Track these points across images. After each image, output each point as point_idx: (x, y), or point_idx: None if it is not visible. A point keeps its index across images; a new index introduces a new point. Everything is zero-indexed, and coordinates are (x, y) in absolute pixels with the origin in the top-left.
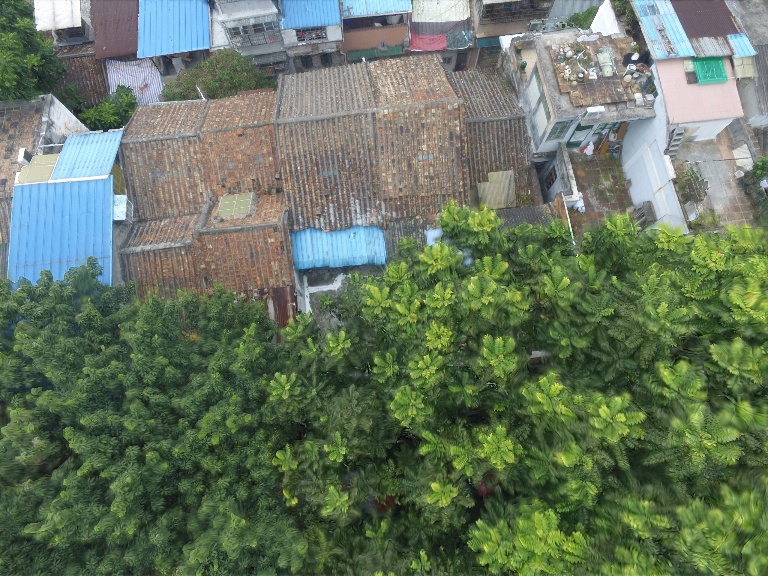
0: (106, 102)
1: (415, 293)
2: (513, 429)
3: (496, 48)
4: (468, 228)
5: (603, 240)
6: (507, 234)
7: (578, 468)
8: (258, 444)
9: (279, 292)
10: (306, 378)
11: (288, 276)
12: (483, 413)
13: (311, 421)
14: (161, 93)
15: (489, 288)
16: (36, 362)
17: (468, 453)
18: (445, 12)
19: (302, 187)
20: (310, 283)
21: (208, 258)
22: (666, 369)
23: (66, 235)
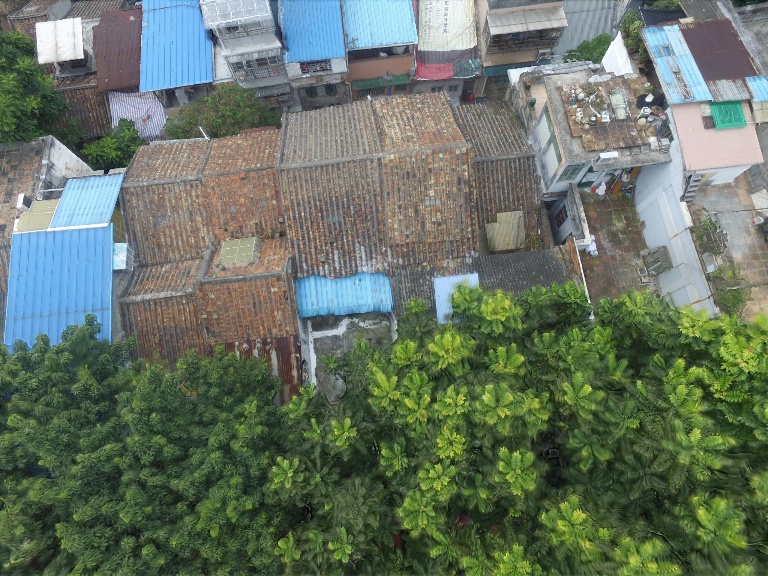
0: (108, 136)
1: (425, 384)
2: (531, 543)
3: (503, 76)
4: (481, 315)
5: (622, 318)
6: (520, 301)
7: None
8: (260, 528)
9: (282, 342)
10: (310, 460)
11: (292, 326)
12: (497, 516)
13: (315, 505)
14: (163, 128)
15: (505, 399)
16: (29, 446)
17: (482, 565)
18: (451, 40)
19: (306, 234)
20: (314, 328)
21: (210, 308)
22: (701, 507)
23: (65, 286)
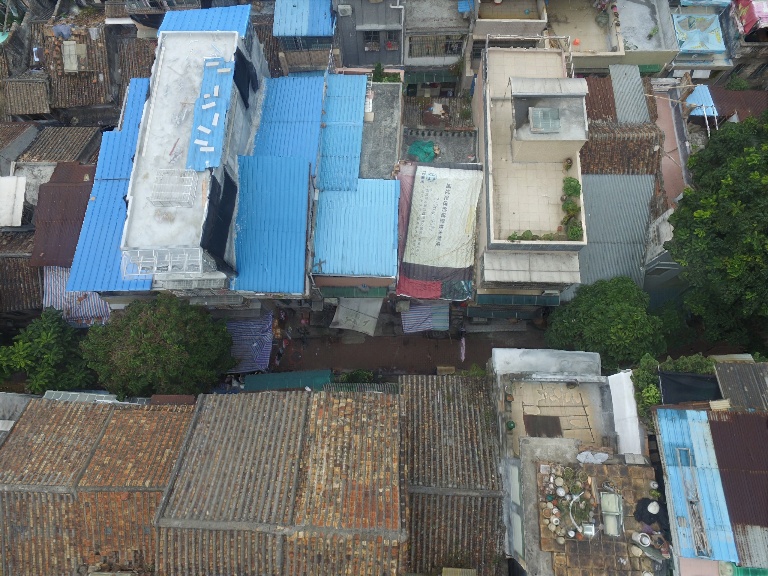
0: (25, 332)
1: None
2: None
3: None
4: None
5: None
6: None
7: None
8: None
9: None
10: None
11: None
12: None
13: None
14: None
15: None
16: None
17: None
18: (444, 256)
19: None
20: None
21: None
22: None
23: None
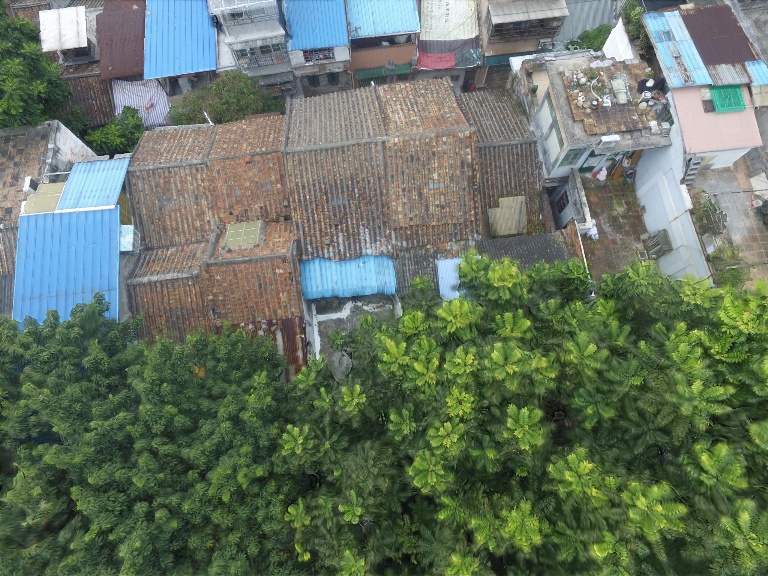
0: (112, 123)
1: (433, 350)
2: (537, 499)
3: (505, 66)
4: (488, 282)
5: (625, 289)
6: (524, 276)
7: (610, 555)
8: (269, 496)
9: (288, 323)
10: (319, 429)
11: (297, 307)
12: (504, 476)
13: (324, 473)
14: (167, 115)
15: (513, 357)
16: (43, 414)
17: (490, 522)
18: (453, 30)
19: (311, 216)
20: (318, 311)
21: (216, 289)
22: (703, 453)
23: (72, 267)
